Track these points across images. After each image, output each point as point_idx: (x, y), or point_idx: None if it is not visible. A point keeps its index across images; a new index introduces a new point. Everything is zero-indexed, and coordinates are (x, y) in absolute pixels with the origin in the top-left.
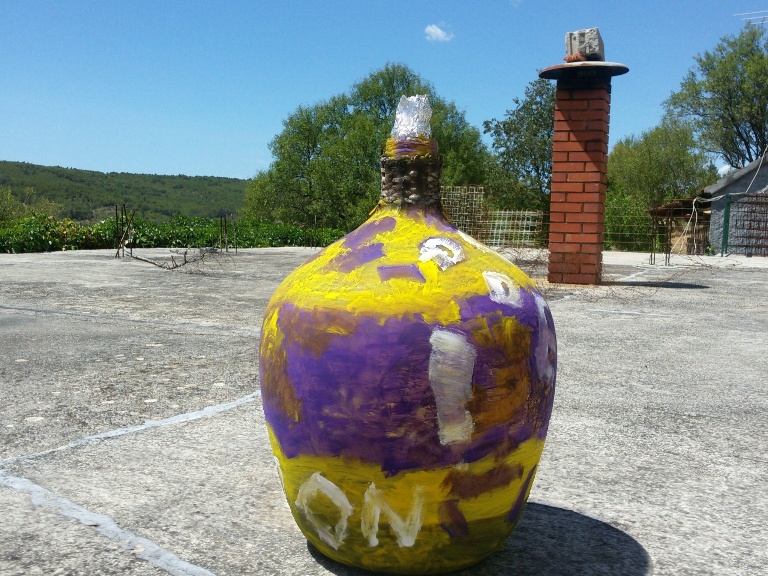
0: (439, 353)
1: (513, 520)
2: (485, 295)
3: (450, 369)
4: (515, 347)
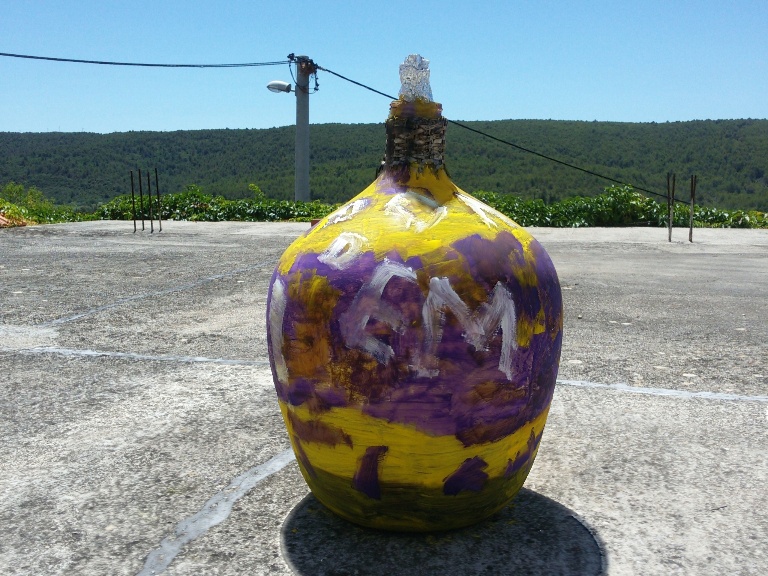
0: (272, 298)
1: (373, 495)
2: (317, 253)
3: (274, 314)
4: (315, 306)
